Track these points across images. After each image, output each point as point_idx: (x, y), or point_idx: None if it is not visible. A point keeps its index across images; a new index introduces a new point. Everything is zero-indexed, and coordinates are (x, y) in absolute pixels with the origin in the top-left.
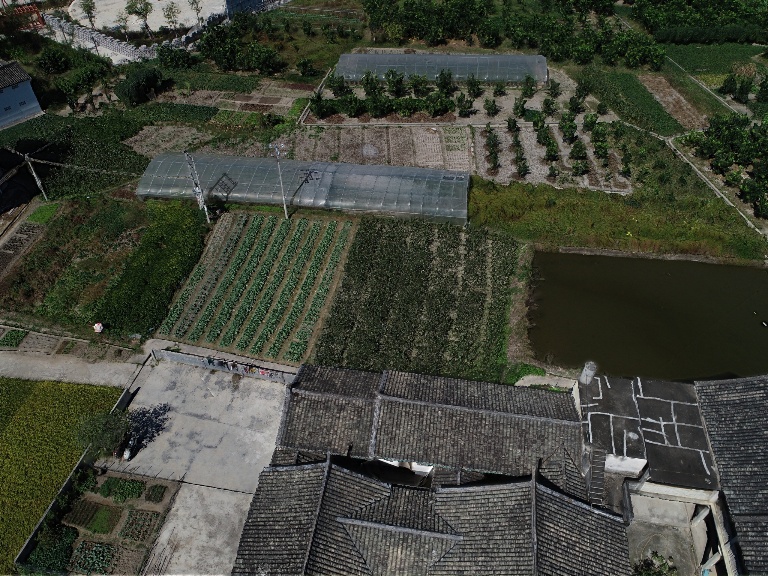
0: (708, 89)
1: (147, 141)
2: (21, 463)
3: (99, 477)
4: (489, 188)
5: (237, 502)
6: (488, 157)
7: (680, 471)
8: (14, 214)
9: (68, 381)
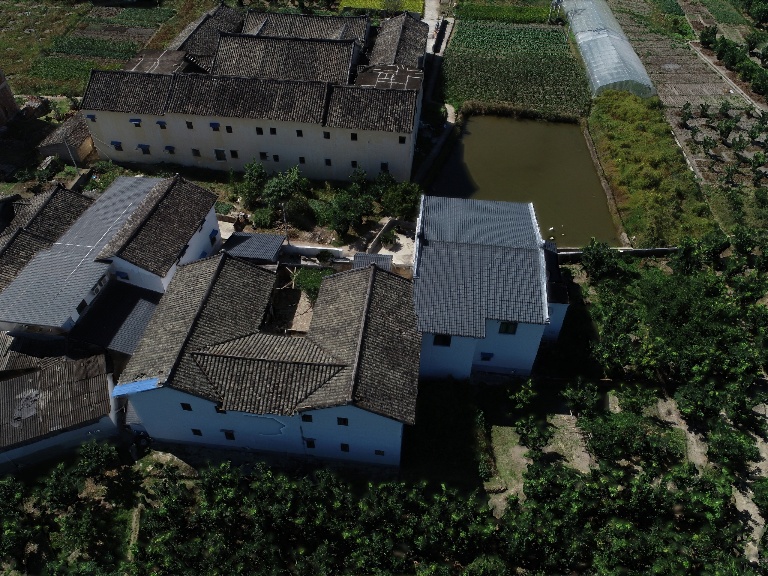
0: None
1: (624, 1)
2: (383, 3)
3: (380, 19)
4: (646, 104)
5: None
6: None
7: None
8: None
9: (425, 7)
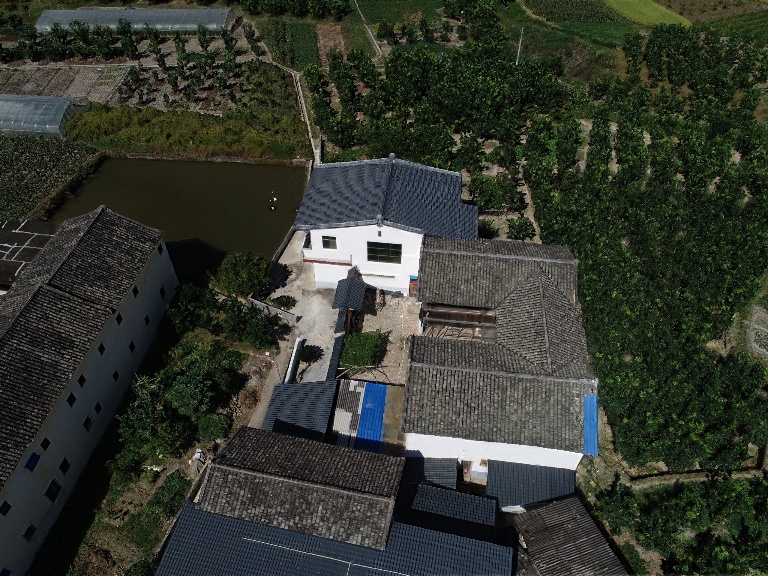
0: (371, 35)
1: None
2: None
3: None
4: (102, 111)
5: None
6: (126, 89)
7: None
8: None
9: None
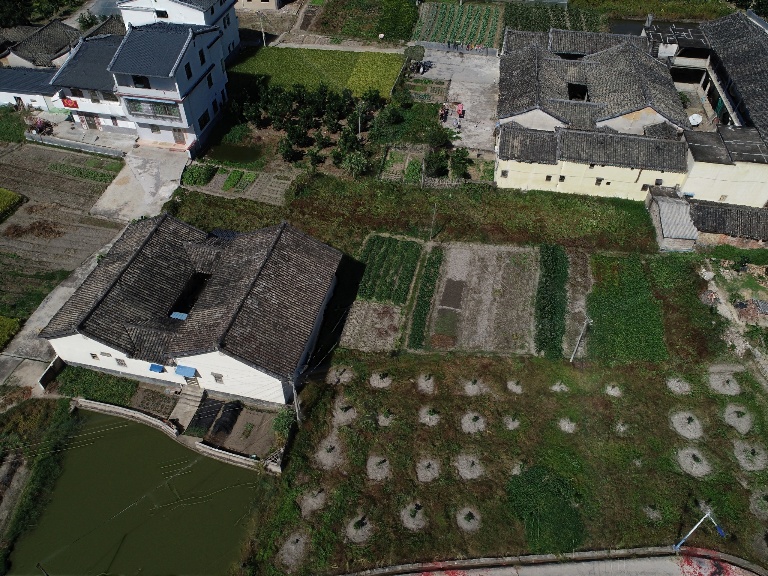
0: None
1: None
2: None
3: (410, 79)
4: None
5: (480, 85)
6: None
7: (693, 43)
8: (300, 2)
9: None
